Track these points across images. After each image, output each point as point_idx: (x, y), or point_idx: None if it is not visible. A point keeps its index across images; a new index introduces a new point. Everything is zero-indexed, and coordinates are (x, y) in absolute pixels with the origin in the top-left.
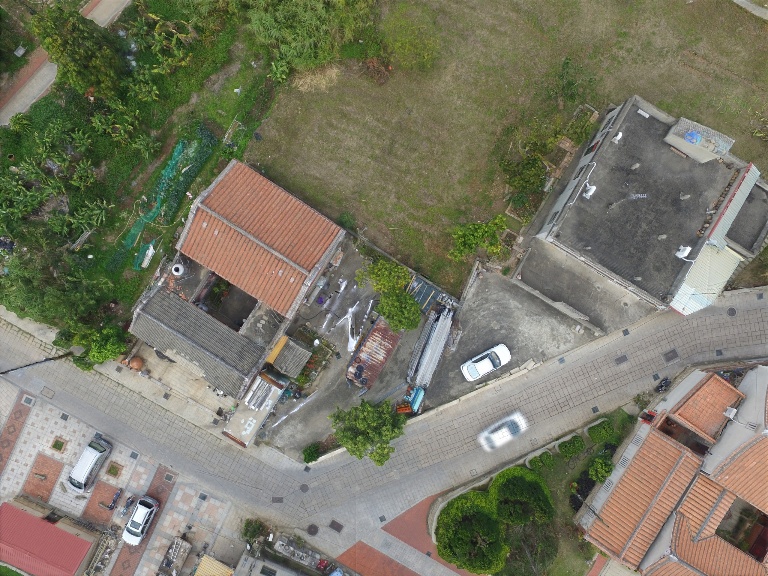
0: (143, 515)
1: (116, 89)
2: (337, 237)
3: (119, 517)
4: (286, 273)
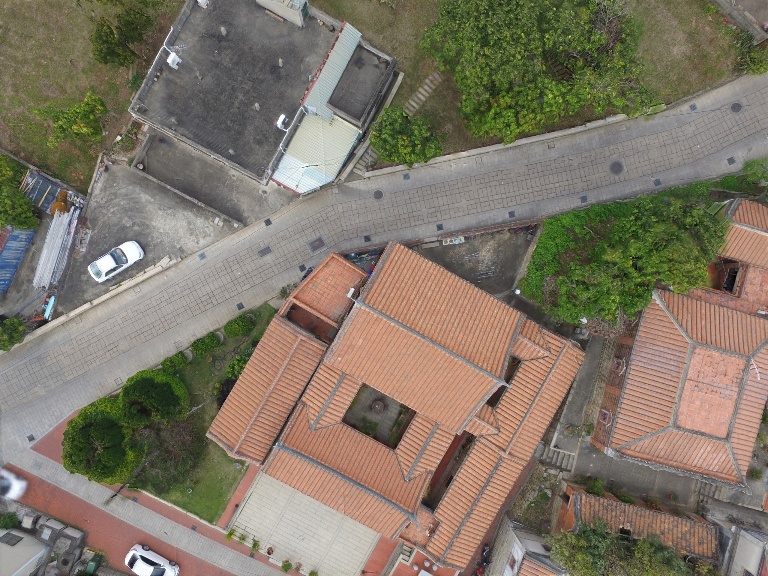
0: None
1: None
2: None
3: None
4: None
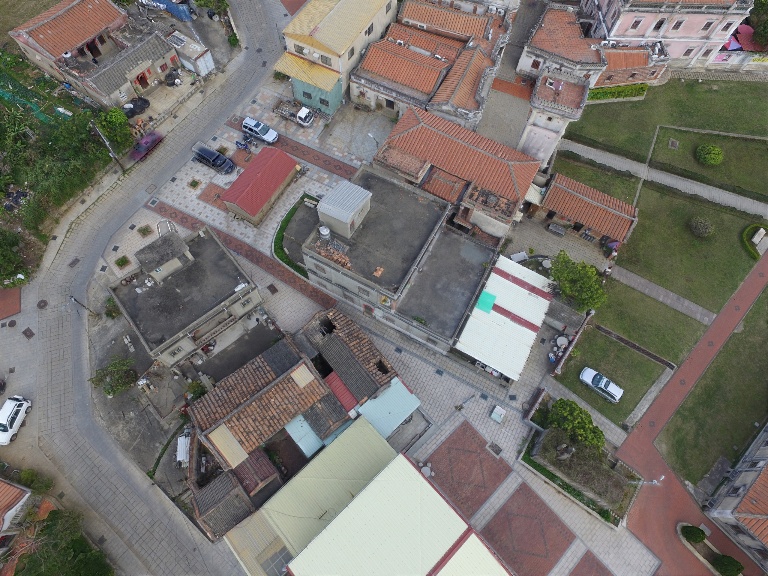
0: (251, 120)
1: None
2: None
3: None
4: (91, 4)
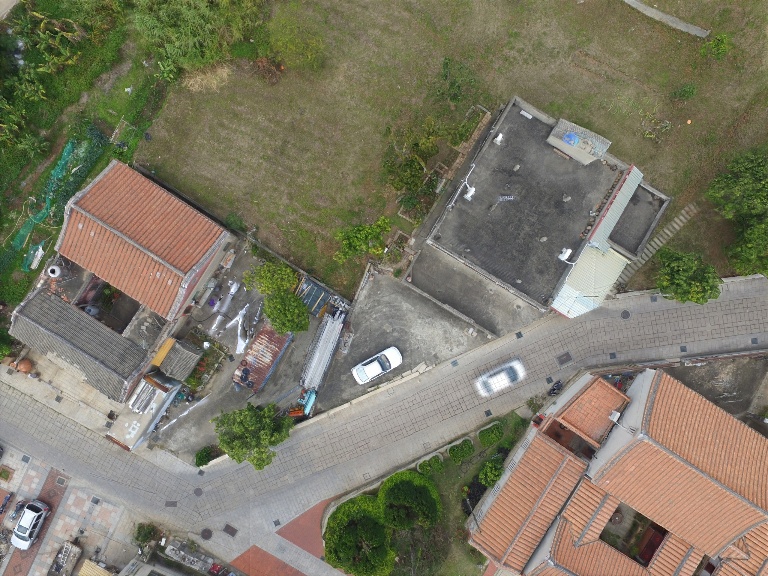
0: (30, 519)
1: (4, 88)
2: (219, 239)
3: (10, 521)
4: (164, 275)
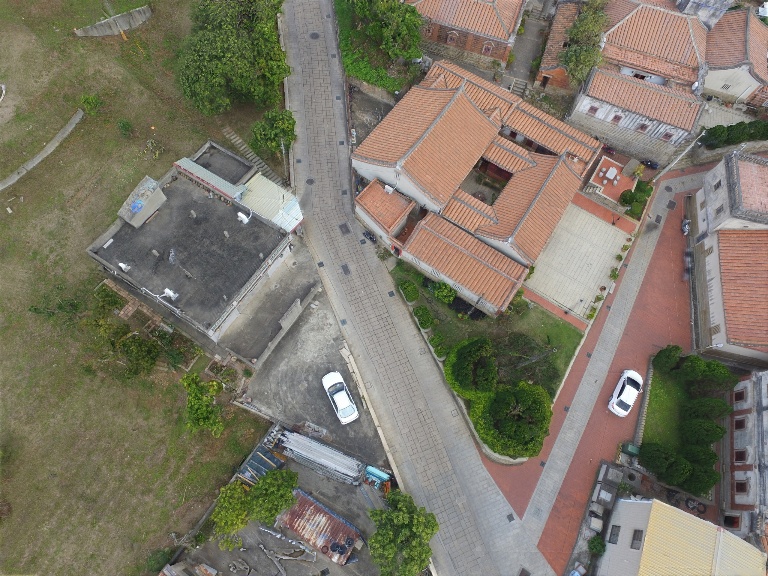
0: None
1: None
2: None
3: None
4: None
